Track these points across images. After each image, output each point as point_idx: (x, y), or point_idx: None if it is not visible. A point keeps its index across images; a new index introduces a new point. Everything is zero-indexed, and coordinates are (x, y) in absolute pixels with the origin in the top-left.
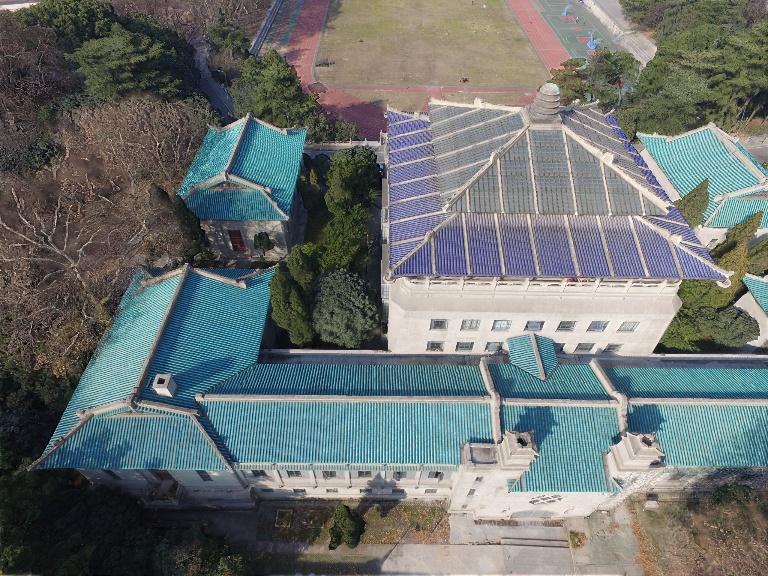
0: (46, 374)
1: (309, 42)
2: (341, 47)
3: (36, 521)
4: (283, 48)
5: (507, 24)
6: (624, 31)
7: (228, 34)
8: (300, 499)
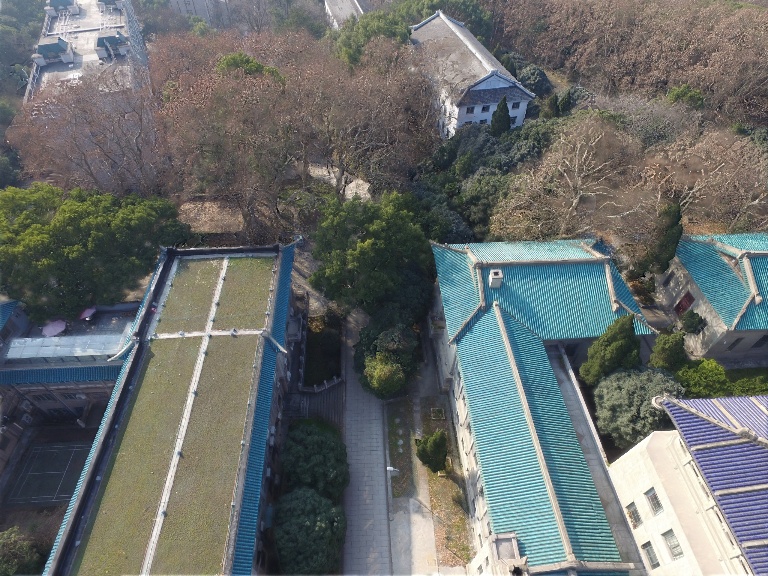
0: None
1: None
2: None
3: (407, 262)
4: None
5: None
6: None
7: None
8: (454, 423)
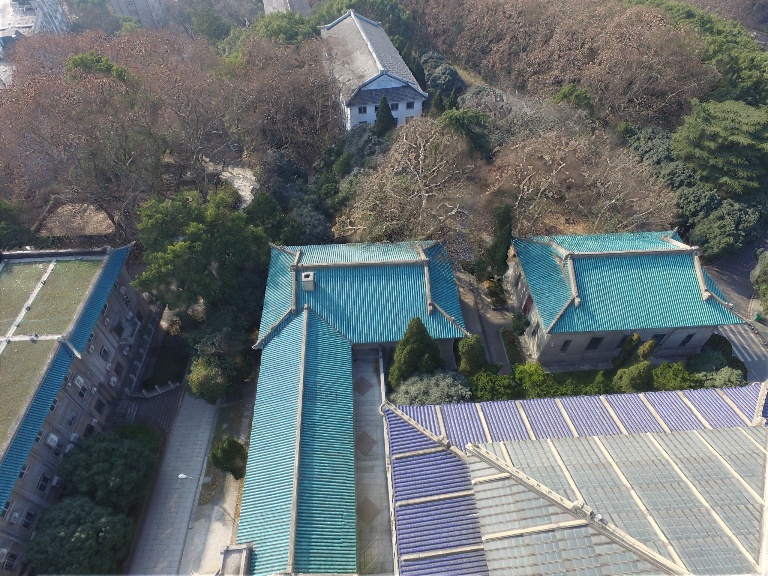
0: None
1: None
2: None
3: None
4: None
5: None
6: None
7: None
8: None
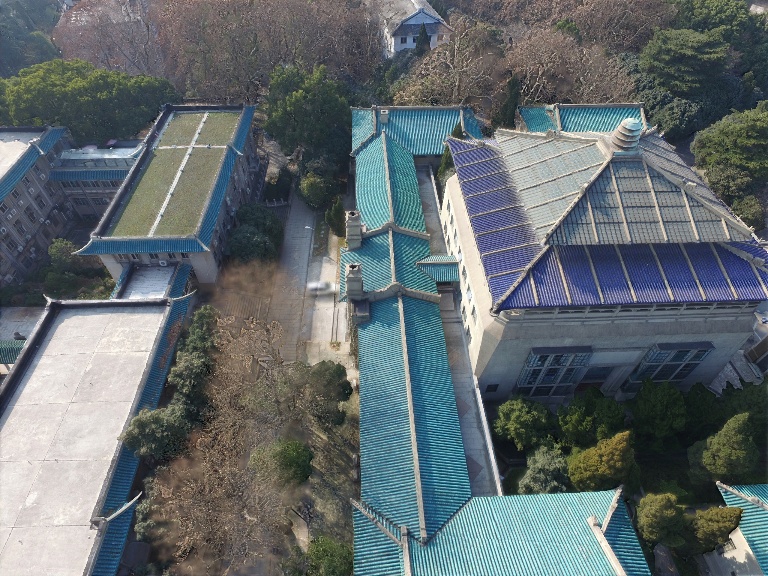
0: None
1: None
2: None
3: None
4: None
5: None
6: None
7: None
8: None
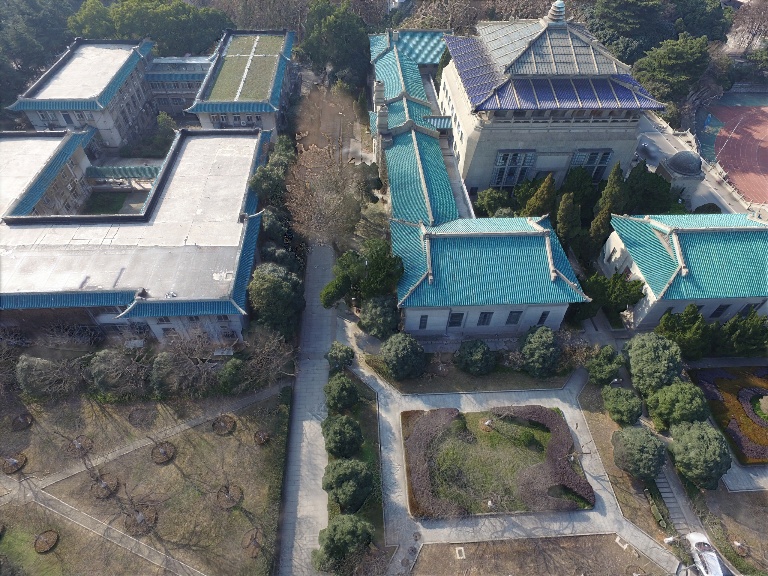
0: None
1: None
2: None
3: None
4: None
5: None
6: None
7: None
8: None
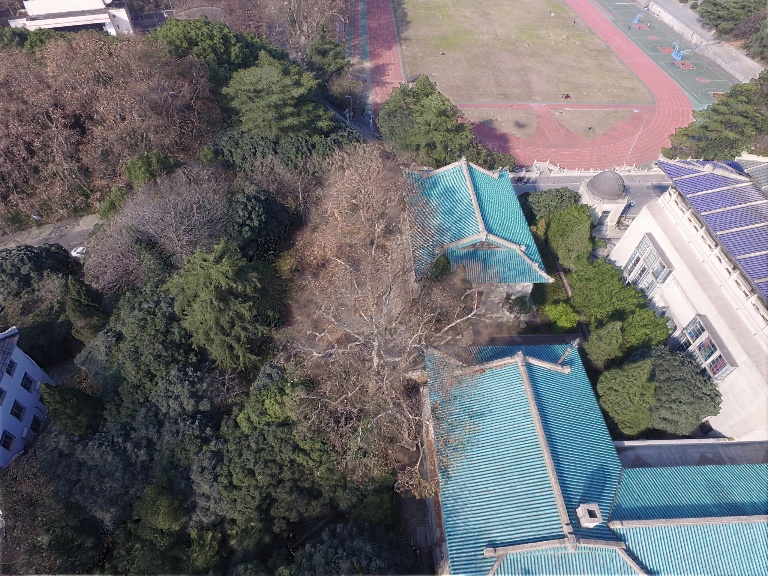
0: (346, 477)
1: (390, 56)
2: (425, 61)
3: None
4: (366, 63)
5: (583, 33)
6: (707, 41)
7: (330, 52)
8: None
